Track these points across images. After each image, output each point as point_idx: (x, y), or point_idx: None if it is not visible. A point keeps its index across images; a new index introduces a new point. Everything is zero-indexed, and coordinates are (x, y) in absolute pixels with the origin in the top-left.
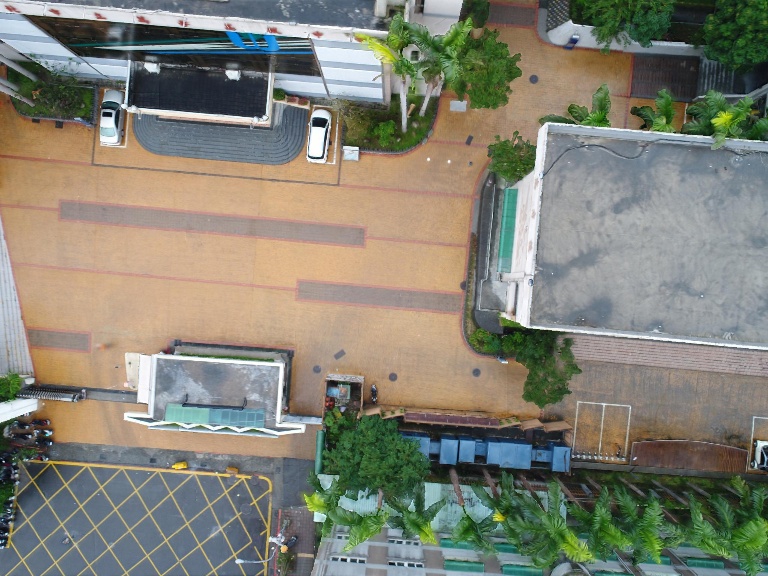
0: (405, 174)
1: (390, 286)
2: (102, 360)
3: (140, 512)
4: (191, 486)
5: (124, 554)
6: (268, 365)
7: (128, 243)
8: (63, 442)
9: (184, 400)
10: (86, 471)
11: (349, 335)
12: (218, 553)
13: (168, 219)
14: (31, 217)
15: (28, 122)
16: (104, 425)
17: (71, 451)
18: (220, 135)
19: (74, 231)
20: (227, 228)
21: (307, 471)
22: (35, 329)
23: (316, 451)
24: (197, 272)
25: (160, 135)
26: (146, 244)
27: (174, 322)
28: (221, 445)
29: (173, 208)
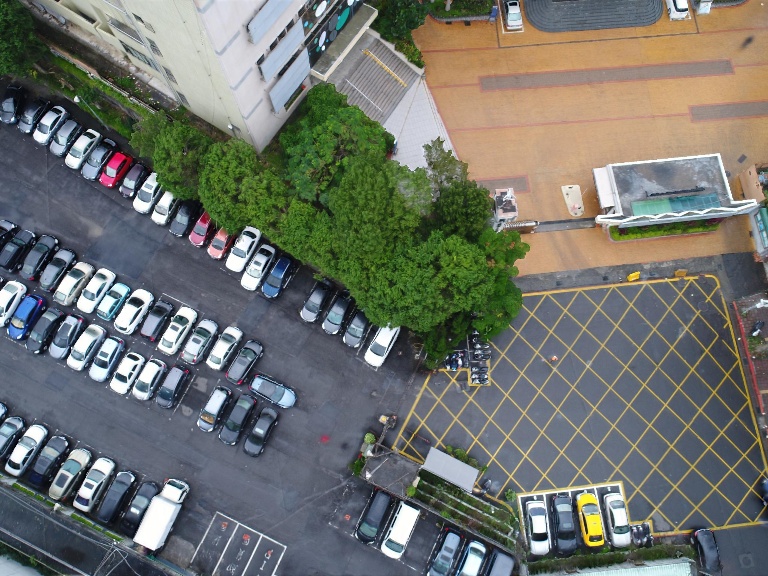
0: (747, 17)
1: (764, 99)
2: (542, 196)
3: (608, 327)
4: (647, 295)
5: (604, 369)
6: (707, 156)
7: (542, 100)
8: (520, 276)
9: (645, 197)
10: (547, 298)
11: (744, 142)
12: (691, 352)
13: (571, 77)
14: (458, 93)
15: (443, 25)
16: (555, 253)
17: (529, 283)
18: (603, 7)
19: (495, 98)
20: (620, 77)
21: (746, 263)
22: (478, 180)
23: (765, 226)
24: (605, 113)
25: (555, 14)
26: (558, 98)
27: (595, 156)
28: (664, 253)
29: (572, 69)
